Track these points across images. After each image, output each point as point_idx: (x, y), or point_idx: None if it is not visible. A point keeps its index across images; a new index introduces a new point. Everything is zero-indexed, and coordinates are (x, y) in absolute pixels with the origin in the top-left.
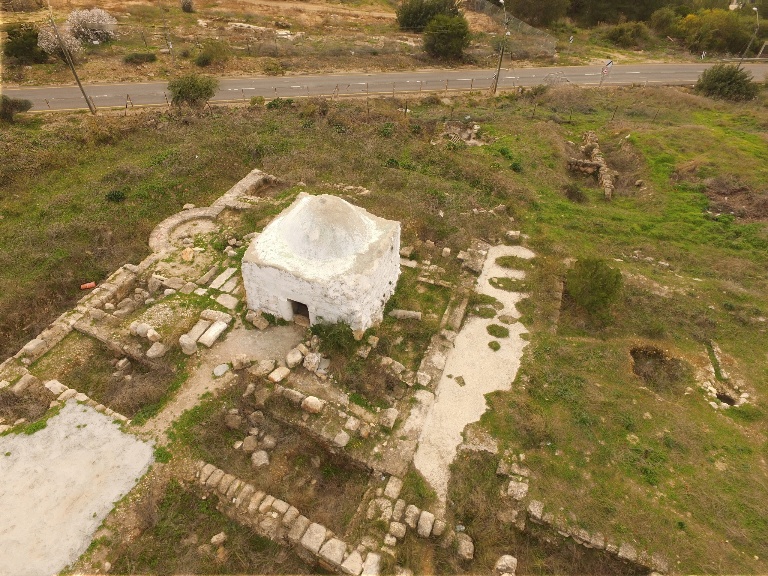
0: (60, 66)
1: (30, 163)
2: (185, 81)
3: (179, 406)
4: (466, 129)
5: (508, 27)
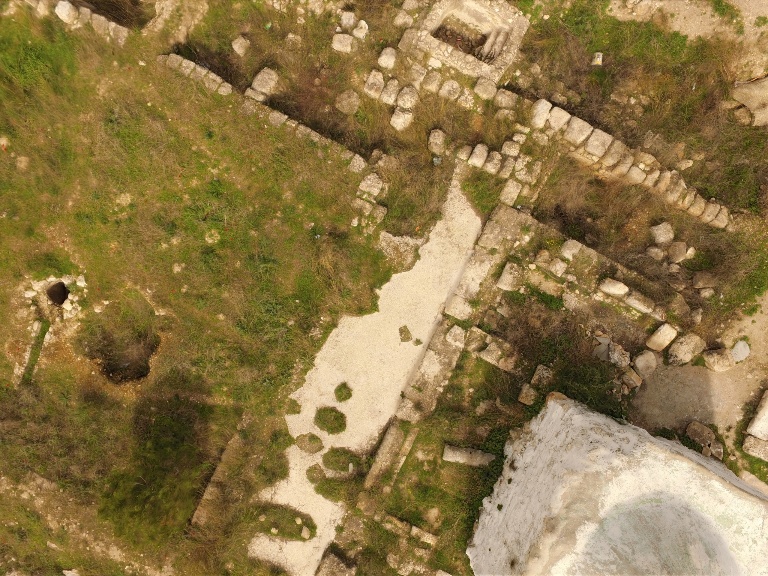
0: None
1: None
2: None
3: None
4: None
5: None
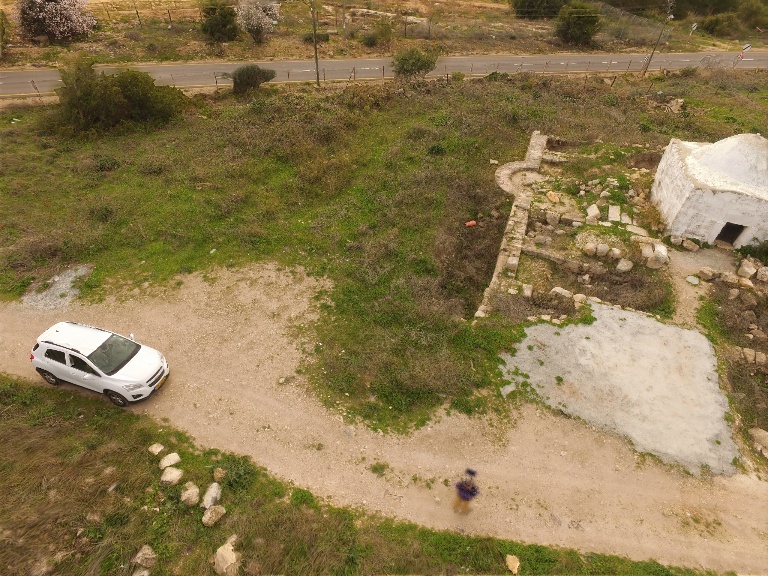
0: (250, 43)
1: (332, 123)
2: (414, 54)
3: (687, 305)
4: (663, 103)
5: (671, 11)
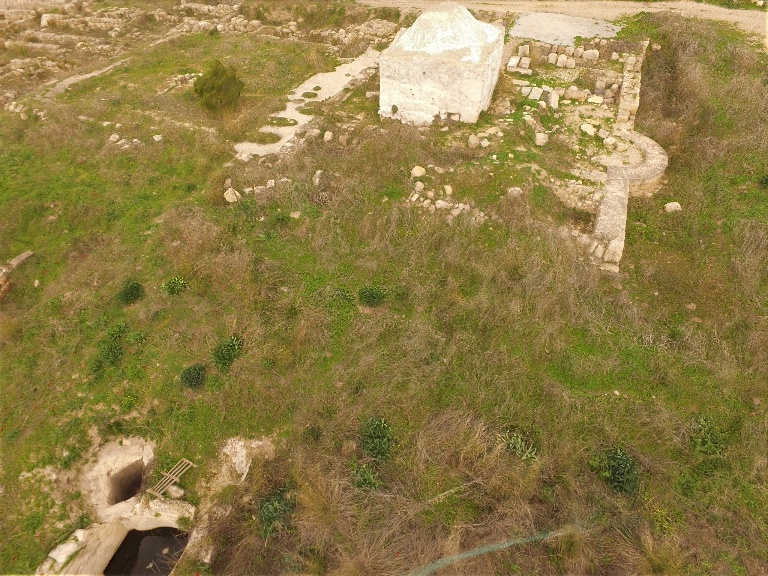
0: None
1: None
2: None
3: (510, 45)
4: None
5: None
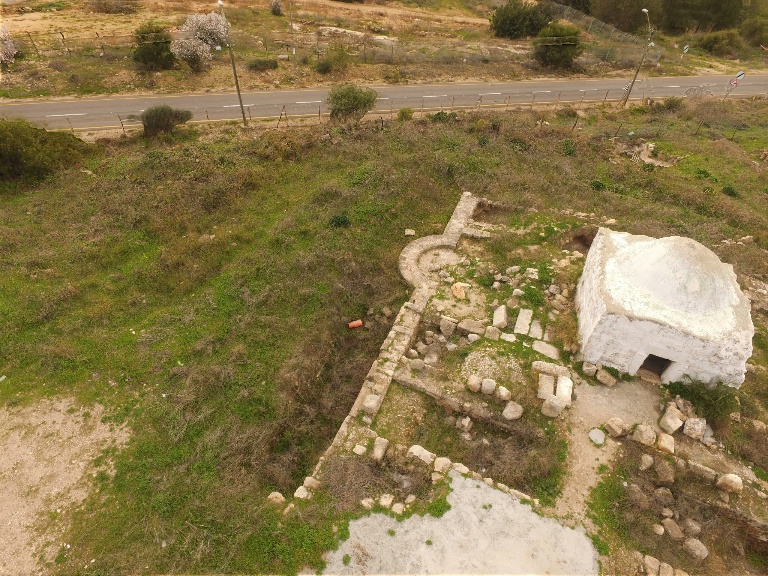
0: (187, 72)
1: (229, 182)
2: (349, 93)
3: (580, 482)
4: (633, 146)
5: (652, 37)
